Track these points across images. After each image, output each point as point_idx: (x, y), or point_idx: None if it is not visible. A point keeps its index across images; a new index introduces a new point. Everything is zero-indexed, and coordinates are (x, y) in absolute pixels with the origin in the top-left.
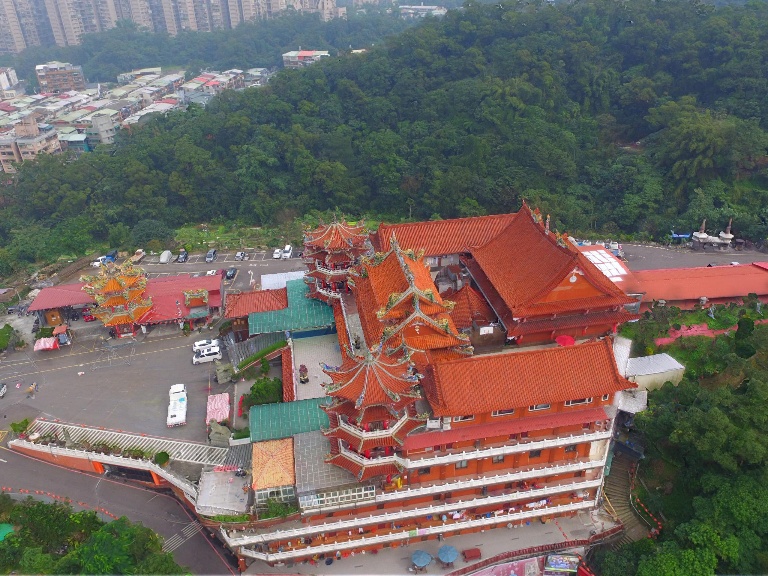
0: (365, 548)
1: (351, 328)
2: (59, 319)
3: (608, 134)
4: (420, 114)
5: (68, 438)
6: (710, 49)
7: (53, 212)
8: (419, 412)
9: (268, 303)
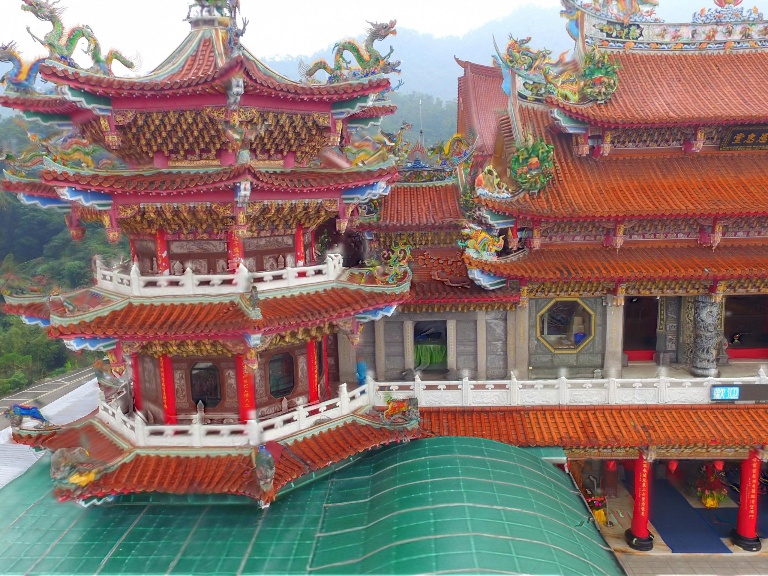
0: None
1: None
2: None
3: None
4: None
5: None
6: None
7: None
8: None
9: None
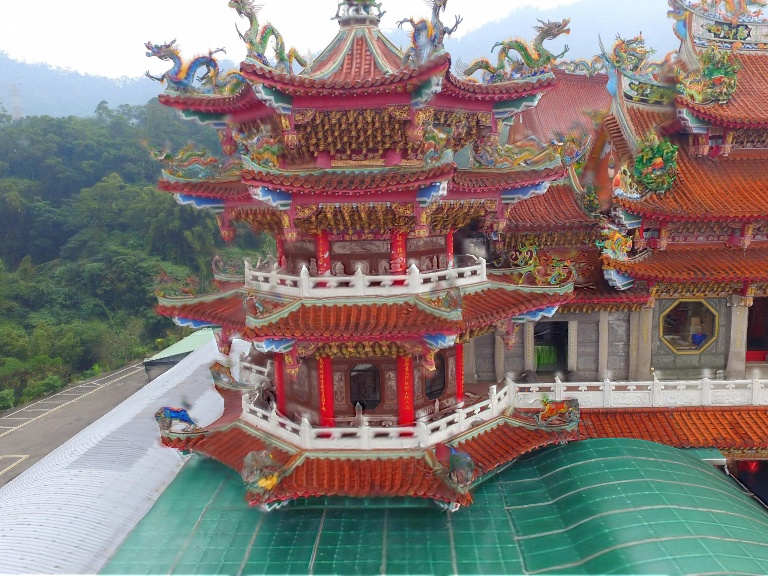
0: None
1: None
2: None
3: None
4: None
5: None
6: (67, 144)
7: None
8: None
9: None
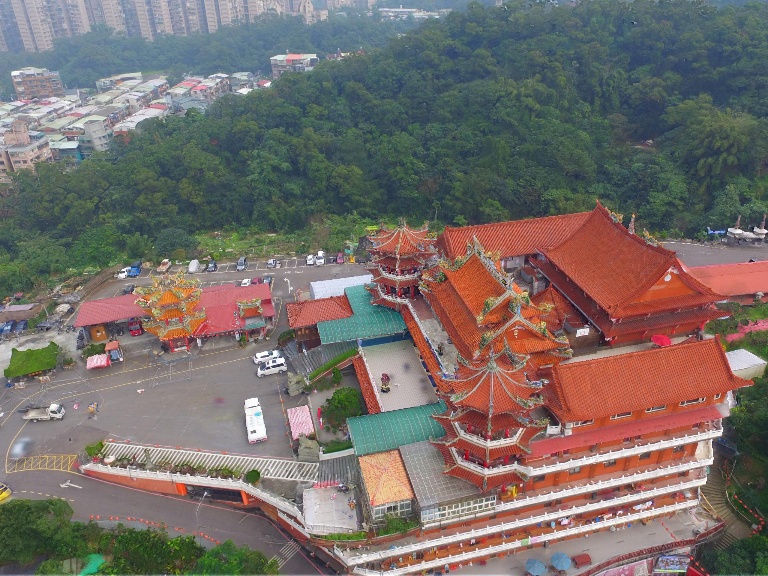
0: (473, 560)
1: (428, 334)
2: (104, 334)
3: (618, 133)
4: (432, 116)
5: (149, 460)
6: (719, 49)
7: (57, 223)
8: (534, 418)
9: (333, 311)
